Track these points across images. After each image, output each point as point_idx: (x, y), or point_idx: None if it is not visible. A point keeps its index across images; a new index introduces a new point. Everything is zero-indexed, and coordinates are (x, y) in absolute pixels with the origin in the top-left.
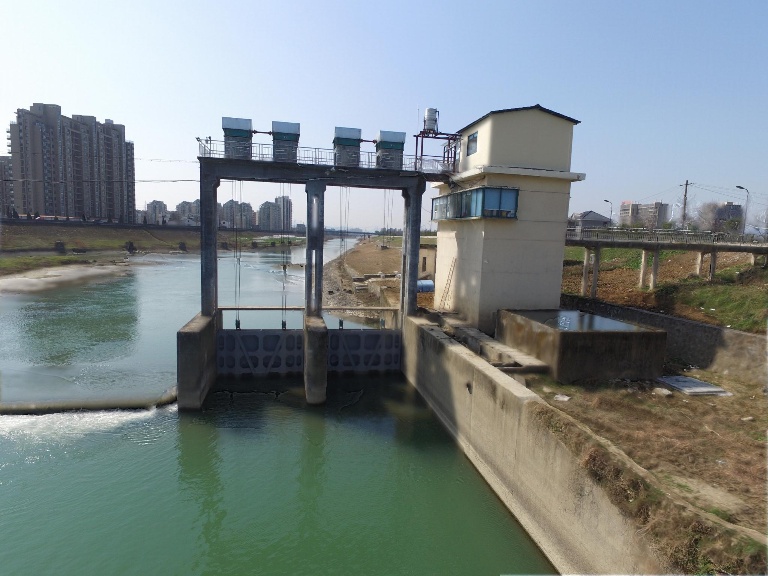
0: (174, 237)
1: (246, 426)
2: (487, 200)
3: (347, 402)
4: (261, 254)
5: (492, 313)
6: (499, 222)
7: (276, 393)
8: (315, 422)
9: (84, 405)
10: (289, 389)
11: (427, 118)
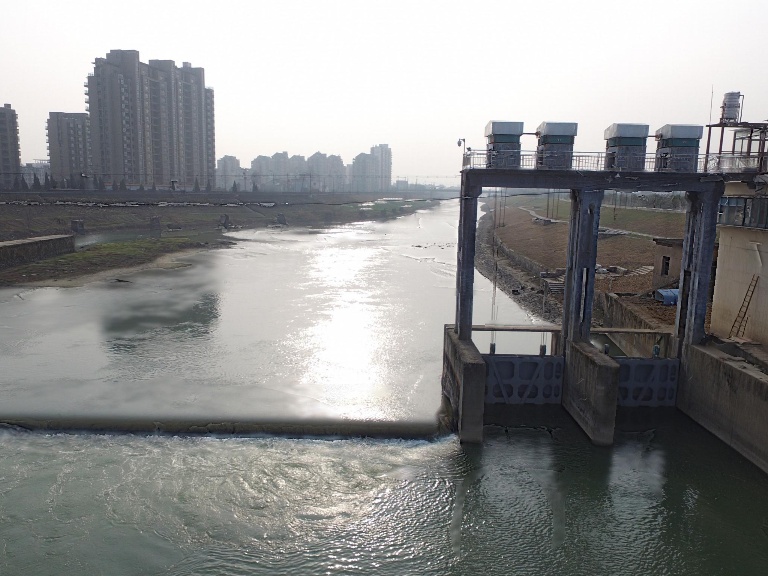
0: None
1: (543, 467)
2: None
3: (637, 446)
4: (381, 229)
5: None
6: None
7: (548, 429)
8: (602, 466)
9: (368, 433)
10: (559, 425)
11: (727, 105)
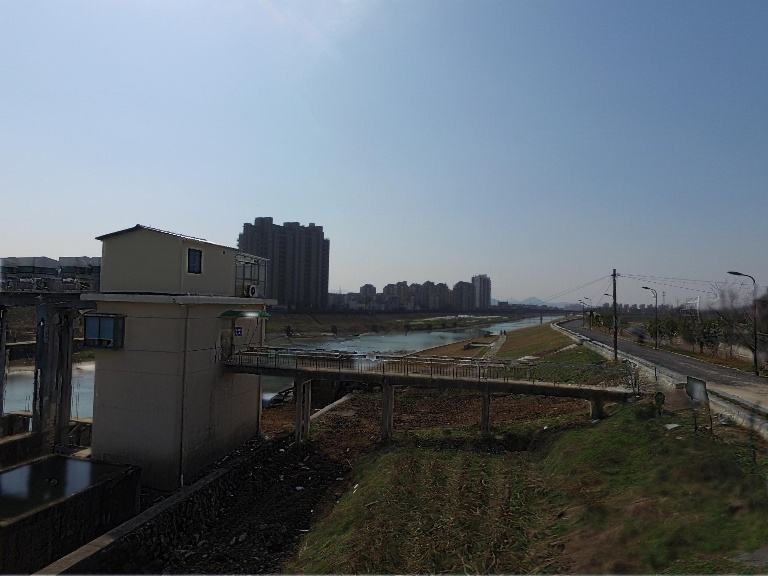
0: (332, 320)
1: None
2: (88, 329)
3: None
4: (386, 338)
5: (103, 454)
6: (101, 352)
7: None
8: None
9: None
10: None
11: None
